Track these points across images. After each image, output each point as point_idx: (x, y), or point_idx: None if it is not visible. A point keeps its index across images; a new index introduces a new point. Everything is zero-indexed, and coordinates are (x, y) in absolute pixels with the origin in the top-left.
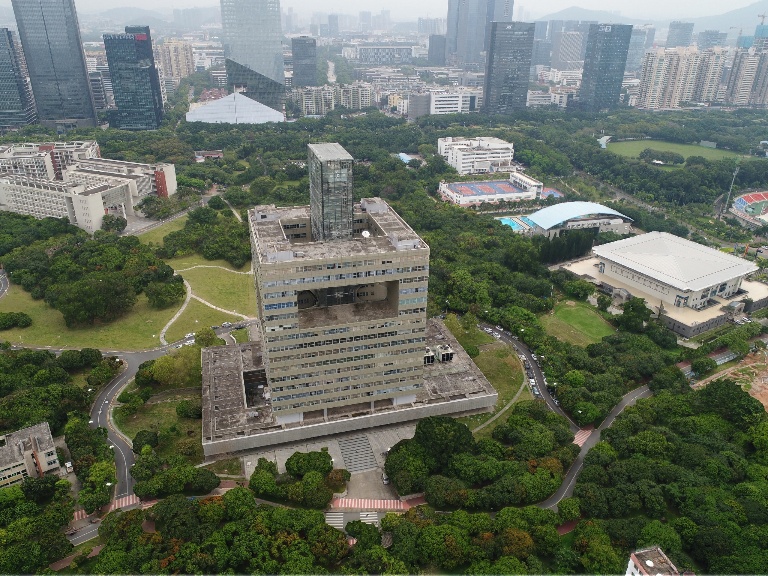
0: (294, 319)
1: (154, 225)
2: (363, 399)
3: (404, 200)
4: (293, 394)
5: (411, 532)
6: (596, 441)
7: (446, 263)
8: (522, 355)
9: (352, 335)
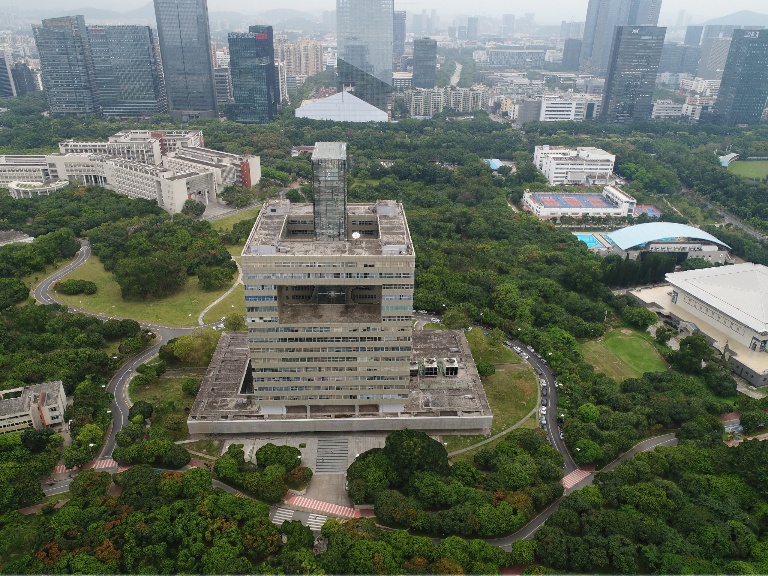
0: (274, 313)
1: (231, 212)
2: (345, 401)
3: (478, 207)
4: (274, 386)
5: (344, 542)
6: (591, 484)
7: (496, 275)
8: (543, 380)
9: (333, 335)
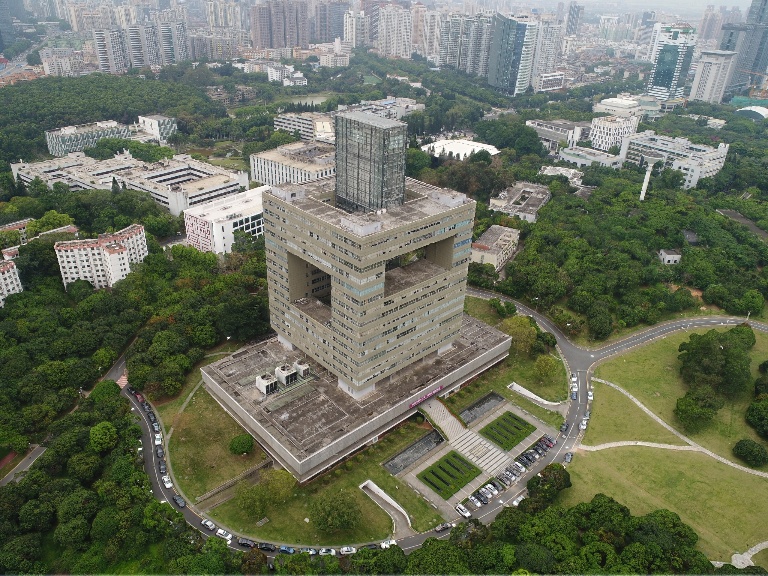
0: None
1: None
2: None
3: None
4: None
5: None
6: None
7: None
8: (168, 482)
9: None
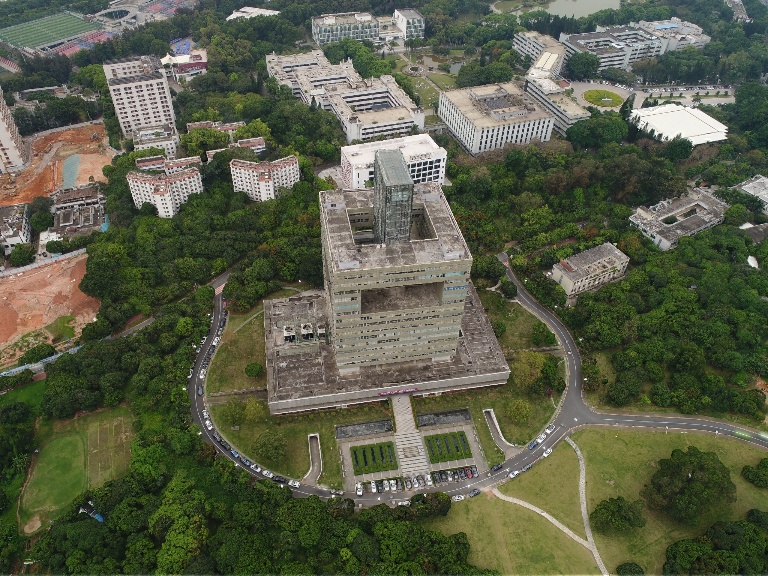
0: None
1: None
2: None
3: None
4: None
5: None
6: None
7: None
8: (202, 374)
9: None
